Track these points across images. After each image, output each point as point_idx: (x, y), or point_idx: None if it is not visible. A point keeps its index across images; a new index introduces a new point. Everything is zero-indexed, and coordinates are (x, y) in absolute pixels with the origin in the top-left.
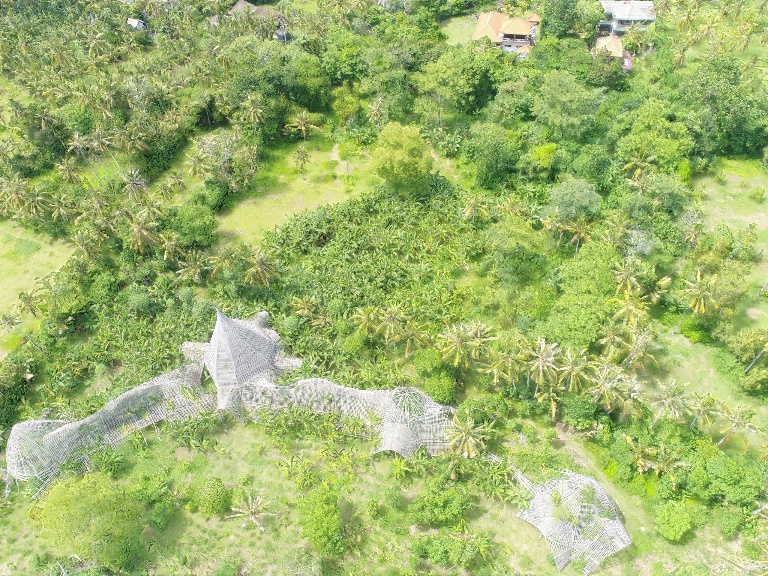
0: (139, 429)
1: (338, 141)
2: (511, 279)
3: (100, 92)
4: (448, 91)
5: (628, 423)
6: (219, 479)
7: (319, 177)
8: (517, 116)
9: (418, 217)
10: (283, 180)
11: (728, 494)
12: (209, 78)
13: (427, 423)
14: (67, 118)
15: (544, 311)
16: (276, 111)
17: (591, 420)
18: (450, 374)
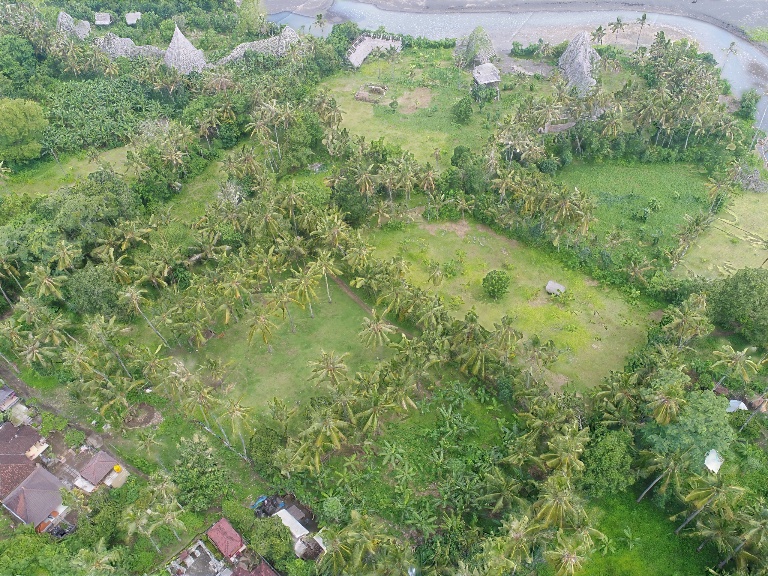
0: None
1: None
2: (16, 93)
3: None
4: None
5: None
6: (207, 40)
7: None
8: None
9: None
10: None
11: None
12: None
13: None
14: None
15: None
16: None
17: None
18: None
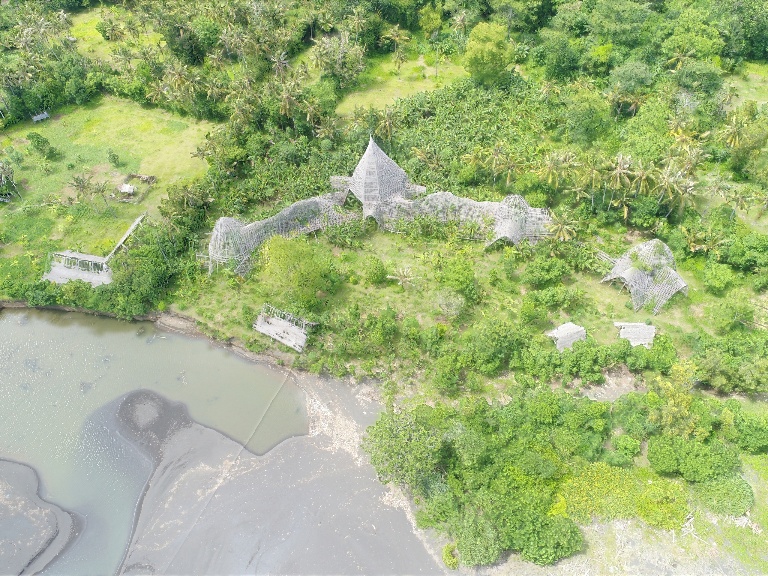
0: (303, 234)
1: (423, 52)
2: None
3: (226, 8)
4: (521, 5)
5: (682, 221)
6: None
7: (411, 77)
8: (573, 34)
9: (501, 100)
10: (381, 80)
11: (759, 259)
12: (310, 3)
13: (531, 220)
14: (201, 28)
15: (613, 151)
16: (373, 25)
17: (654, 218)
18: (543, 194)
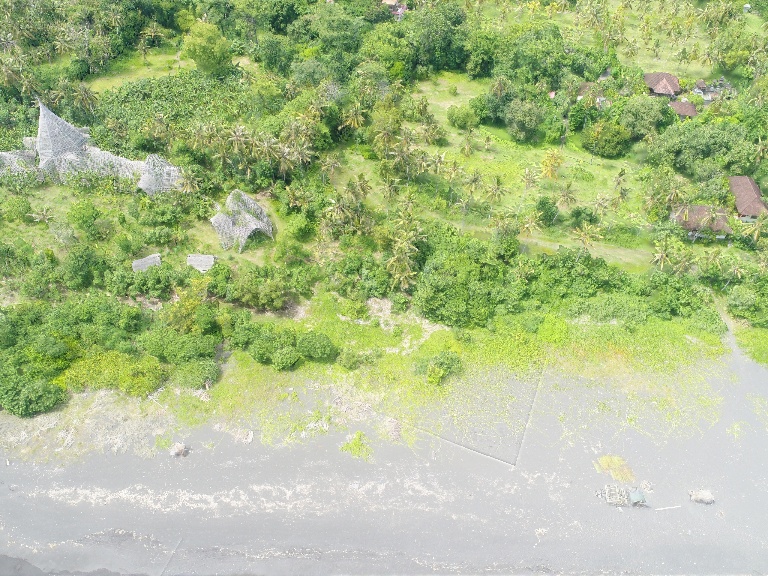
0: None
1: (182, 49)
2: None
3: None
4: (254, 12)
5: None
6: None
7: (159, 68)
8: None
9: None
10: (133, 68)
11: None
12: (94, 2)
13: (166, 176)
14: None
15: None
16: (135, 22)
17: (269, 180)
18: (194, 158)
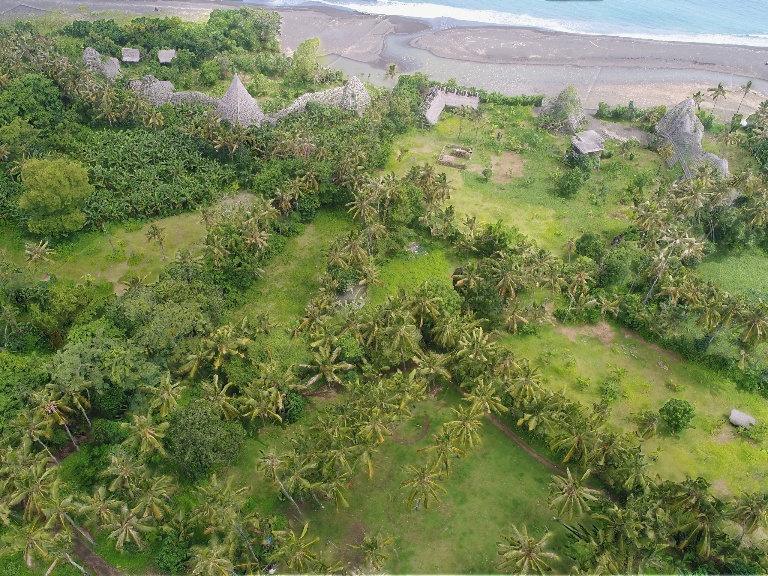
0: None
1: None
2: (42, 144)
3: None
4: None
5: None
6: (258, 87)
7: None
8: None
9: None
10: None
11: None
12: None
13: None
14: None
15: None
16: None
17: None
18: None
